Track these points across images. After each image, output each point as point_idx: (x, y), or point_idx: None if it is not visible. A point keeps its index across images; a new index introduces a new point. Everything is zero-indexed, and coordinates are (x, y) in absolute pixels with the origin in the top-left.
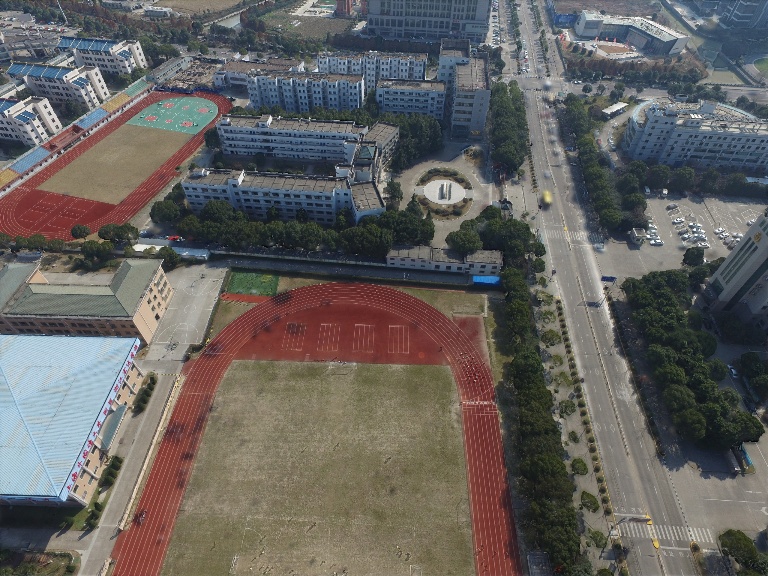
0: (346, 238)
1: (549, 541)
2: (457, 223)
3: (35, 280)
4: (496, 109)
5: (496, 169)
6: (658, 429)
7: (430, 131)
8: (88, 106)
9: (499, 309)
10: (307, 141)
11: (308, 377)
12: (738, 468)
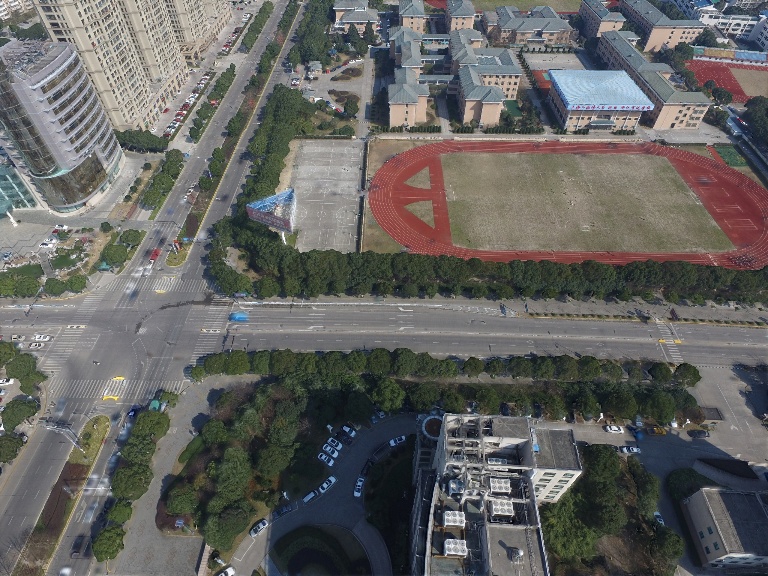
0: None
1: None
2: None
3: None
4: None
5: None
6: None
7: None
8: None
9: None
10: None
11: (676, 185)
12: (767, 416)
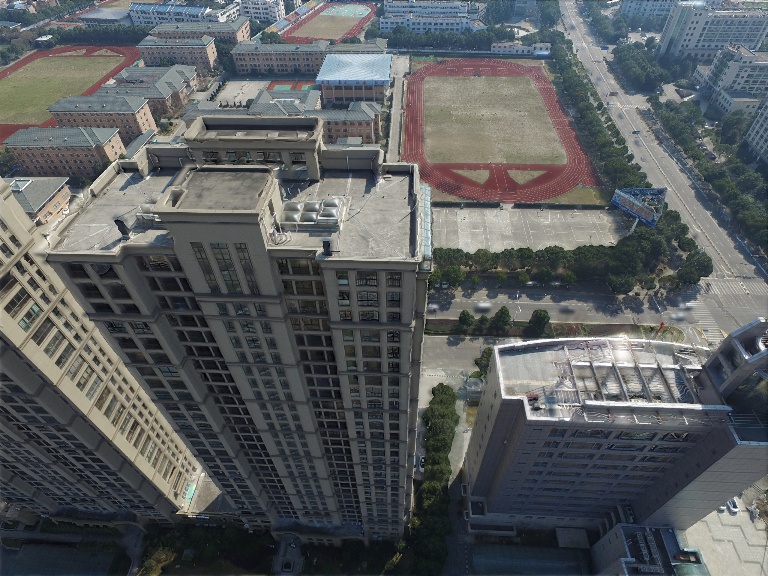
0: (471, 37)
1: (577, 94)
2: None
3: None
4: None
5: (543, 25)
6: None
7: (504, 7)
8: (295, 7)
9: (550, 64)
10: (435, 11)
11: (463, 80)
12: (659, 92)
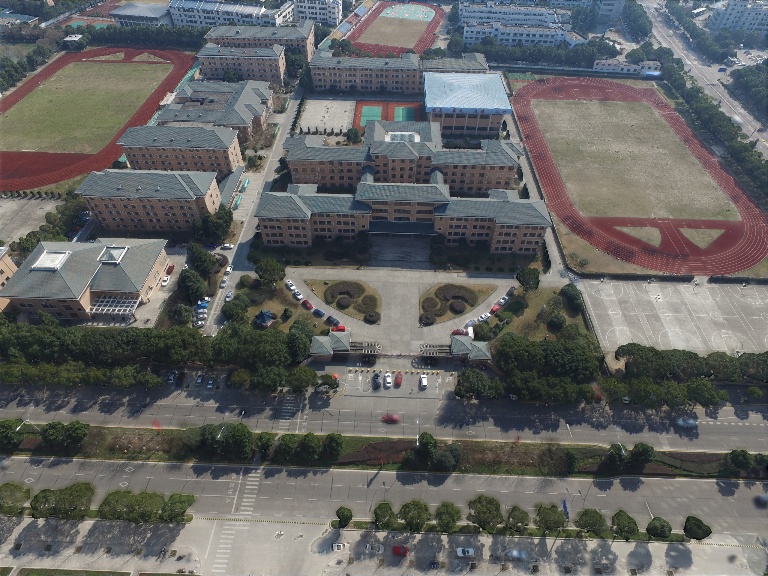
0: (572, 52)
1: (725, 131)
2: (621, 57)
3: None
4: (628, 4)
5: (633, 37)
6: (761, 119)
7: (589, 15)
8: None
9: (663, 86)
10: (516, 18)
11: (575, 104)
12: None
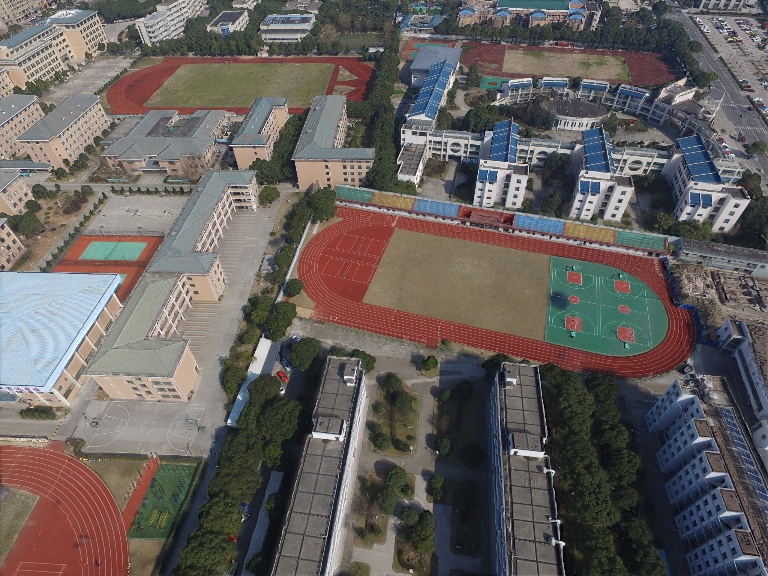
0: None
1: None
2: None
3: (200, 279)
4: None
5: None
6: None
7: None
8: (571, 211)
9: None
10: None
11: None
12: None
